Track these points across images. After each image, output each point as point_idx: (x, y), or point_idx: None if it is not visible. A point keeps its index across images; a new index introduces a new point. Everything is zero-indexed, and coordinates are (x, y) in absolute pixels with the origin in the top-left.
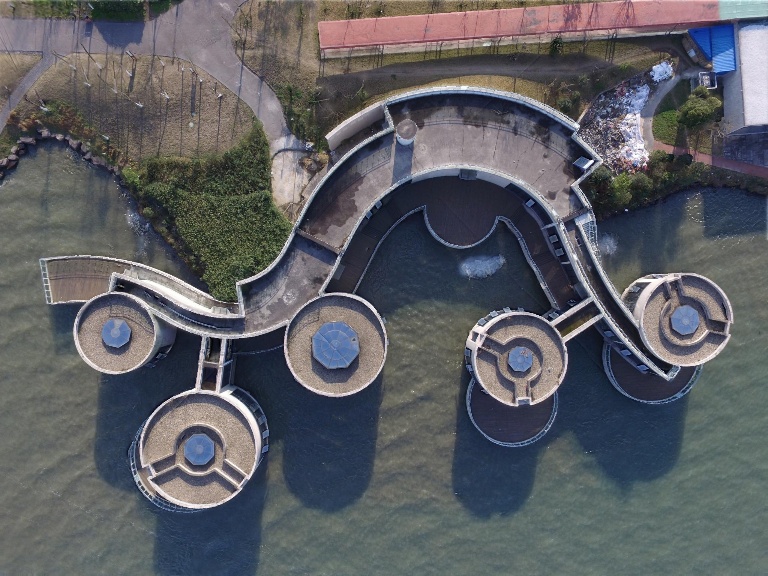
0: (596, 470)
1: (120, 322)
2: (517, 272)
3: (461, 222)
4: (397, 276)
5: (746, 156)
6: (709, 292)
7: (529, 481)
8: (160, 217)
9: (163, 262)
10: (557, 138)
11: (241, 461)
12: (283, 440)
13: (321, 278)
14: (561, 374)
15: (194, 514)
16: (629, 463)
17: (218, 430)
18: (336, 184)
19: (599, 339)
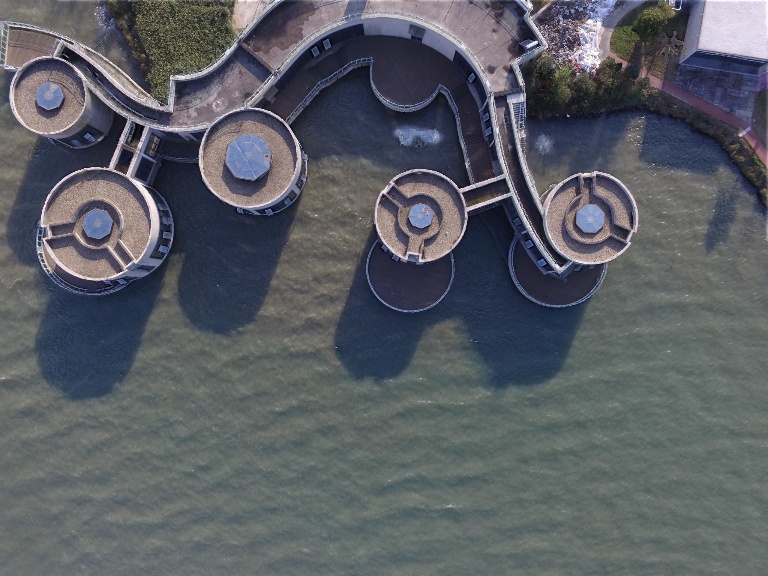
0: (477, 360)
1: (56, 87)
2: (448, 151)
3: (403, 84)
4: (332, 126)
5: (697, 89)
6: (621, 198)
7: (409, 354)
8: (125, 15)
9: (117, 58)
10: (510, 16)
11: (134, 246)
12: (186, 253)
13: (252, 94)
14: (457, 240)
15: (85, 300)
16: (511, 362)
17: (120, 211)
18: (289, 9)
19: (511, 233)
